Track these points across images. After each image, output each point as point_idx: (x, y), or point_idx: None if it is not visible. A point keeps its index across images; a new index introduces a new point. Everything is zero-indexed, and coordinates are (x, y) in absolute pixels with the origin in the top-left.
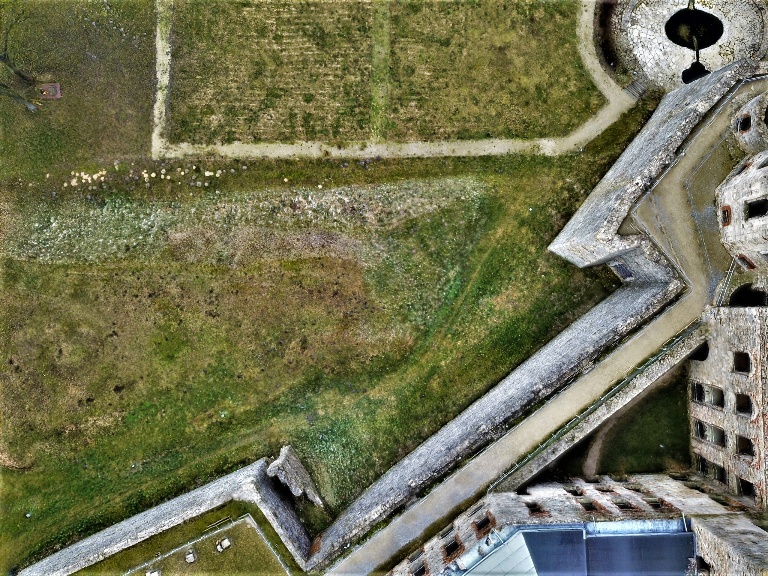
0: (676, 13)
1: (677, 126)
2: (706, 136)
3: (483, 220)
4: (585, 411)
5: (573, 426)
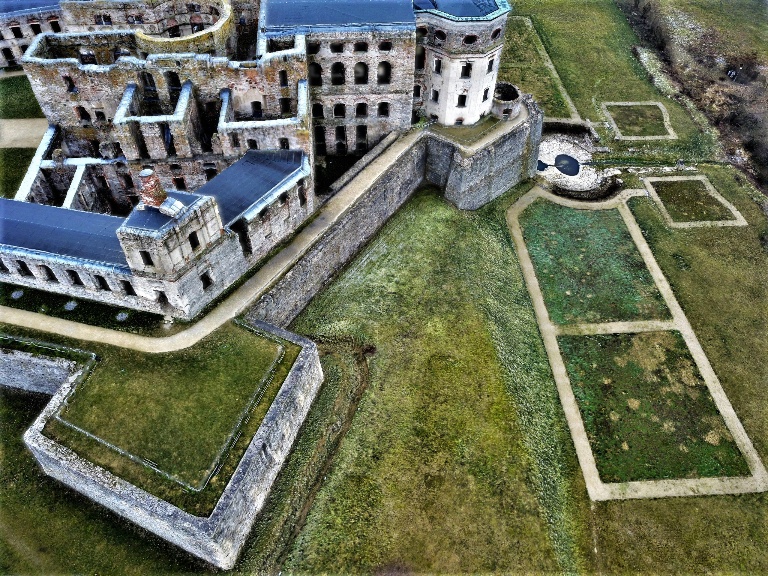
0: (574, 158)
1: None
2: None
3: None
4: None
5: None
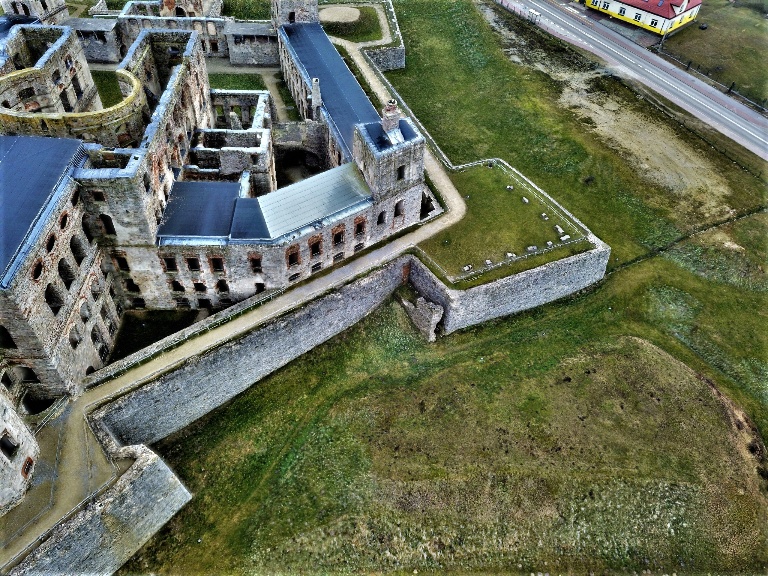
0: None
1: (35, 570)
2: (6, 561)
3: (250, 530)
4: (202, 331)
5: (214, 324)
